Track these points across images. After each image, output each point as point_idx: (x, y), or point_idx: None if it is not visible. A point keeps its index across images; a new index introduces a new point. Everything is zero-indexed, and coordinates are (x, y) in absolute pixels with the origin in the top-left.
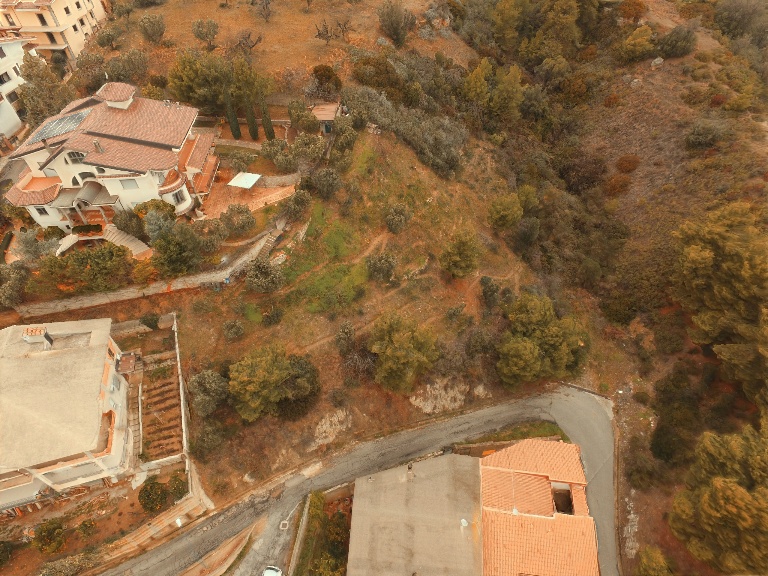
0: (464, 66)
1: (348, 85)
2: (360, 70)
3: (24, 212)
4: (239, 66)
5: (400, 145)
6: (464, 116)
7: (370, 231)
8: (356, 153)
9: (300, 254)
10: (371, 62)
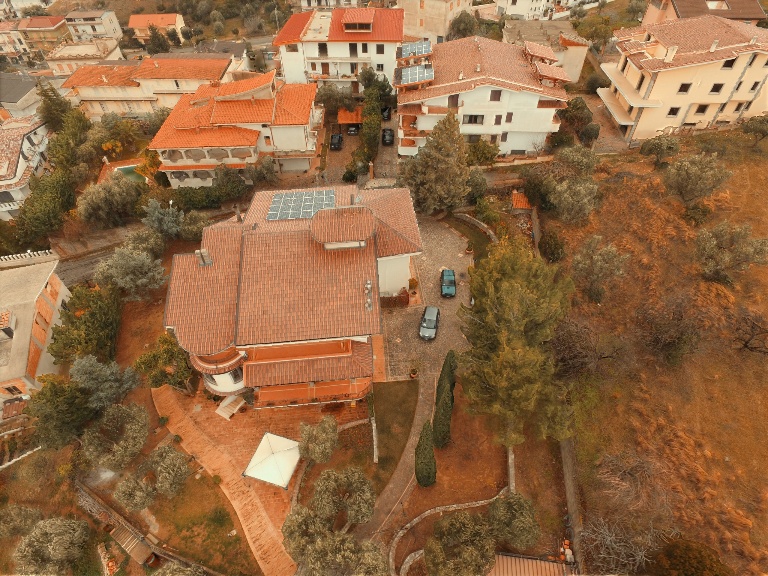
0: None
1: None
2: None
3: None
4: (505, 359)
5: None
6: None
7: None
8: None
9: None
10: None
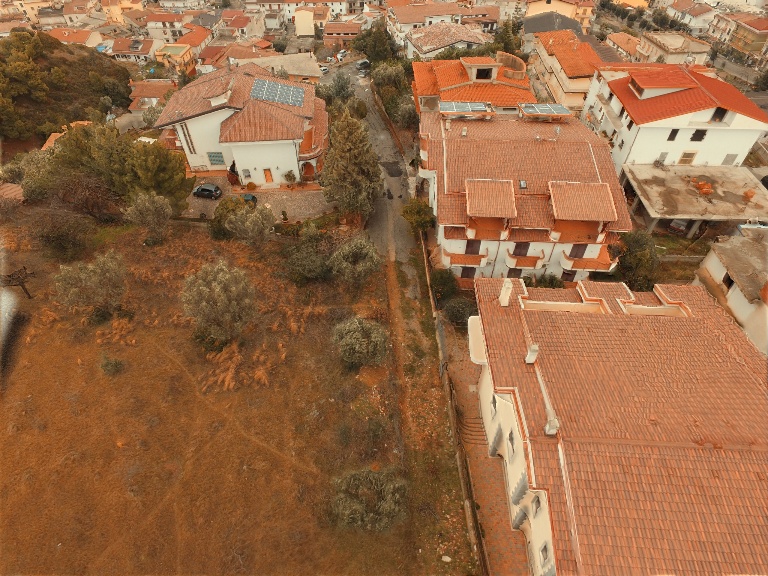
0: None
1: None
2: None
3: None
4: None
5: None
6: None
7: None
8: None
9: None
10: None
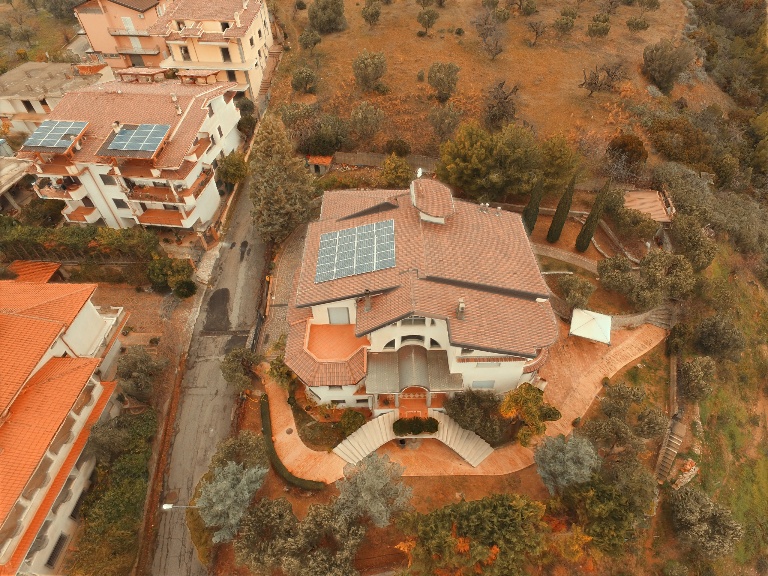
0: (725, 118)
1: (652, 160)
2: (664, 139)
3: (291, 371)
4: (559, 147)
5: (731, 249)
6: (765, 195)
7: (751, 398)
8: (706, 272)
9: (709, 461)
10: (676, 128)
